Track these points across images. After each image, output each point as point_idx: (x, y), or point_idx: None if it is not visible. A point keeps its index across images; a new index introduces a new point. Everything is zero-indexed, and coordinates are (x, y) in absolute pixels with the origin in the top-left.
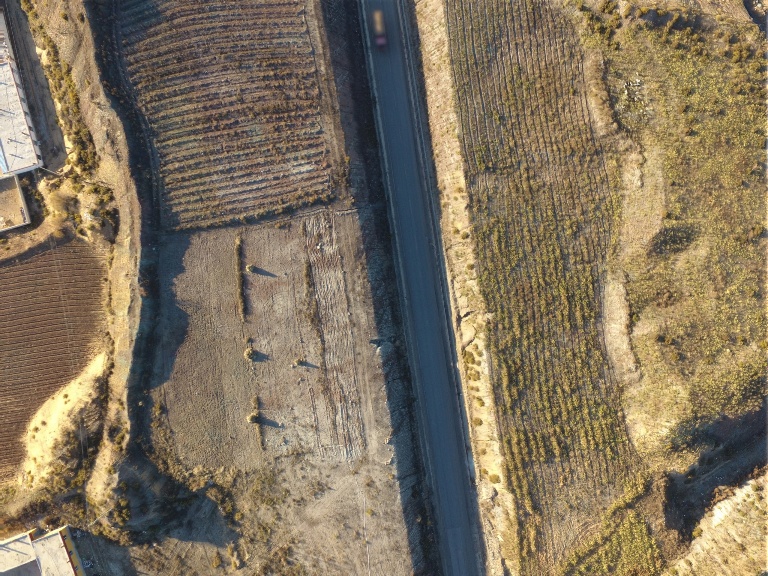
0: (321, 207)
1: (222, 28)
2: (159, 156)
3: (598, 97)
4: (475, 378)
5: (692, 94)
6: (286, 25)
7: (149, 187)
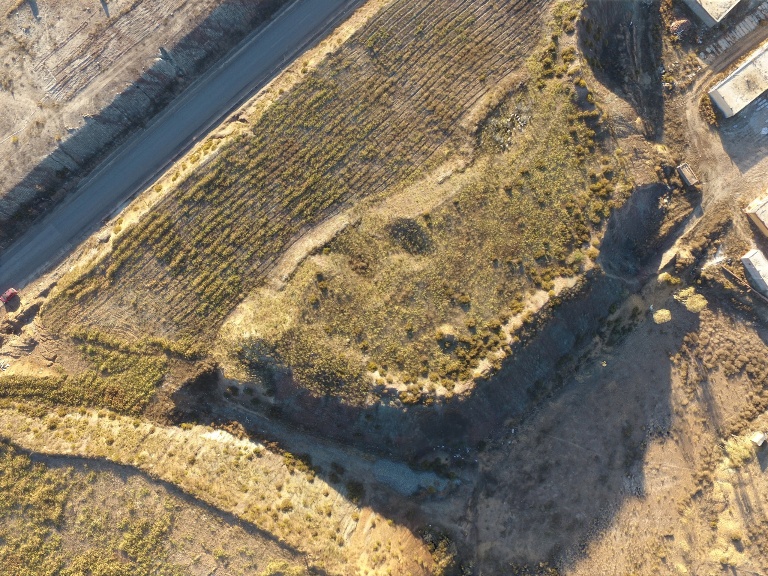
0: None
1: None
2: None
3: (490, 99)
4: (192, 160)
5: (541, 170)
6: None
7: None
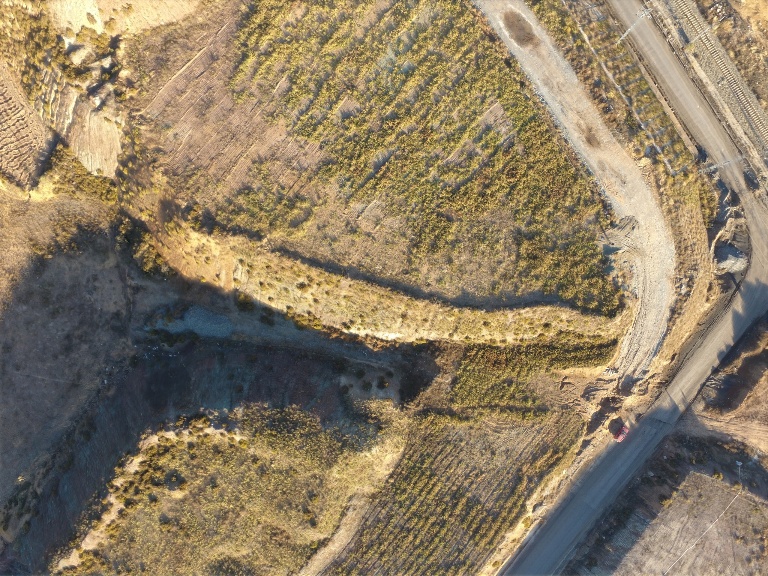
0: None
1: None
2: None
3: None
4: None
5: None
6: None
7: None
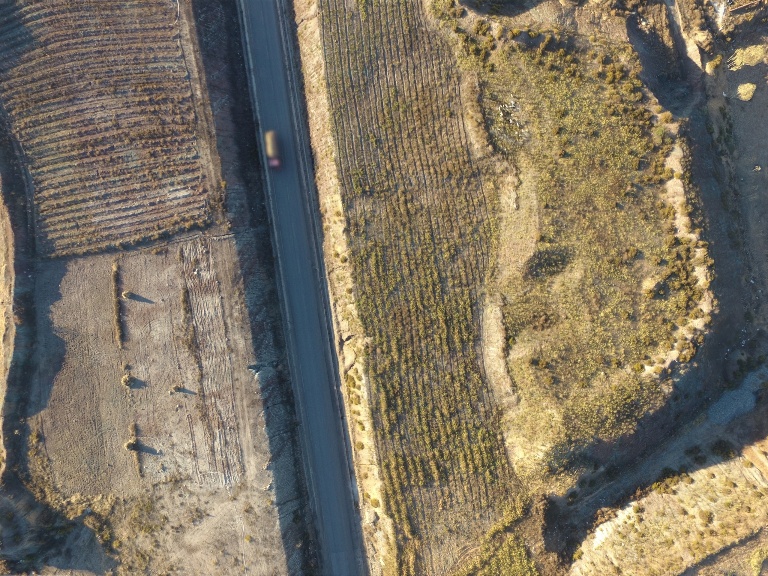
0: (198, 232)
1: (97, 53)
2: (33, 183)
3: (473, 119)
4: (356, 402)
5: (565, 116)
6: (161, 49)
7: (24, 214)
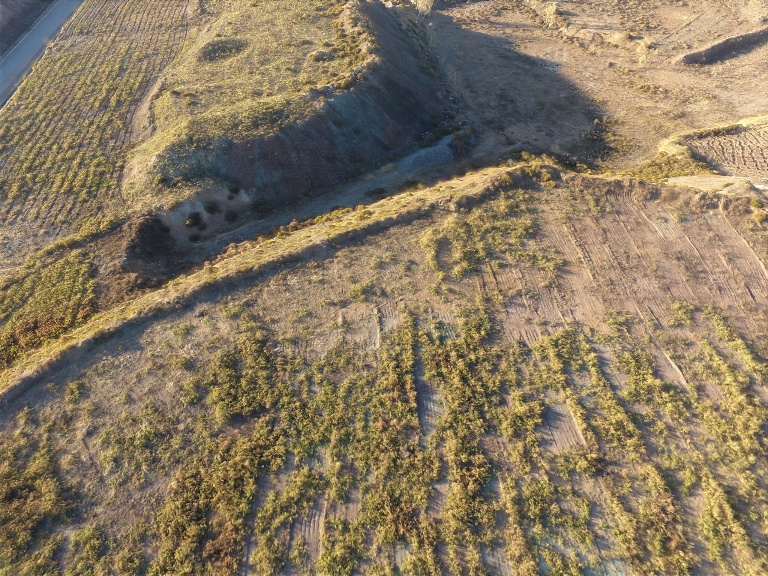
0: None
1: None
2: None
3: None
4: None
5: None
6: None
7: None
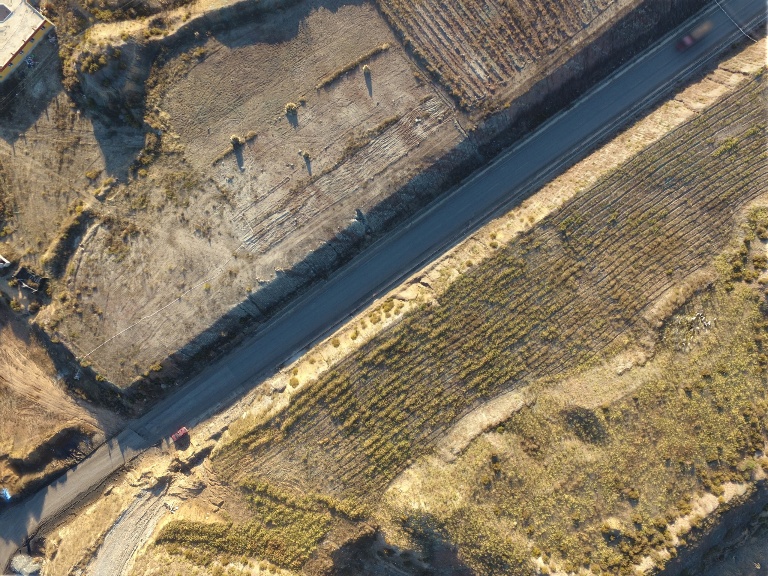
0: (453, 104)
1: None
2: None
3: (677, 296)
4: (373, 320)
5: (723, 375)
6: None
7: None
